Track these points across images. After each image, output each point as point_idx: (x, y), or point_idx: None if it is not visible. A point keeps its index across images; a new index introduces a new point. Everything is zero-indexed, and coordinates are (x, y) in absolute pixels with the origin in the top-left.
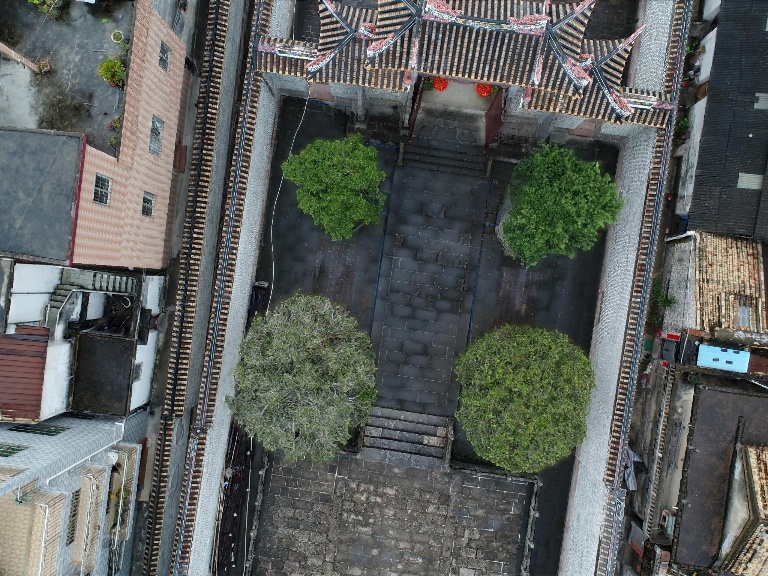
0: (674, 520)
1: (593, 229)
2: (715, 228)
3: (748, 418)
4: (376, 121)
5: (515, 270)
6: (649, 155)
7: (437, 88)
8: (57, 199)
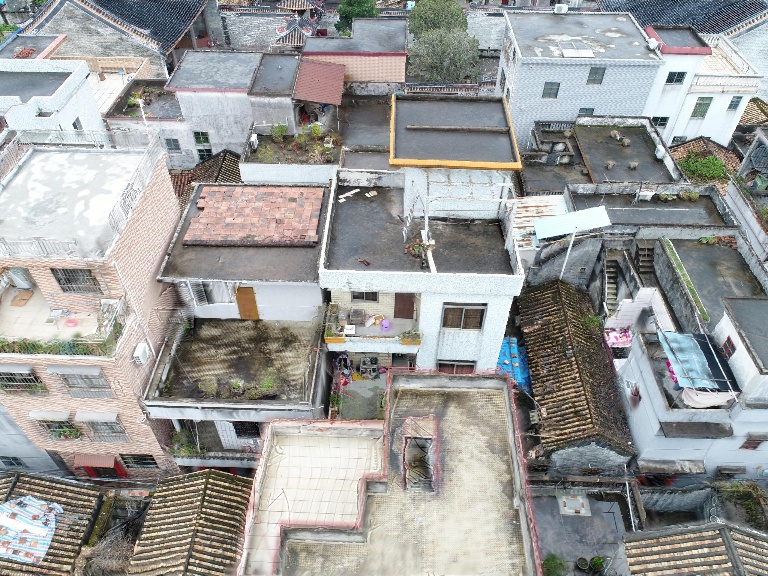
0: (474, 1)
1: None
2: None
3: None
4: None
5: None
6: (333, 20)
7: None
8: (381, 22)
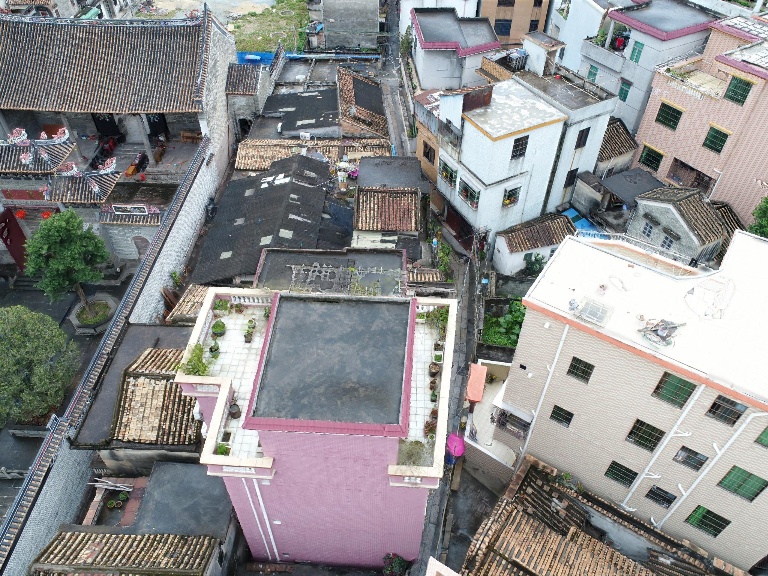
0: None
1: (58, 234)
2: (204, 281)
3: (163, 339)
4: (2, 266)
5: (80, 343)
6: None
7: (17, 215)
8: None
